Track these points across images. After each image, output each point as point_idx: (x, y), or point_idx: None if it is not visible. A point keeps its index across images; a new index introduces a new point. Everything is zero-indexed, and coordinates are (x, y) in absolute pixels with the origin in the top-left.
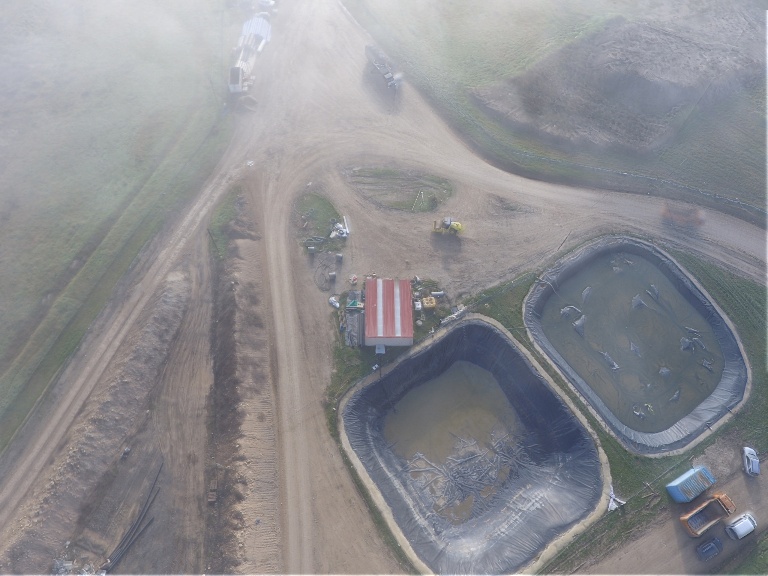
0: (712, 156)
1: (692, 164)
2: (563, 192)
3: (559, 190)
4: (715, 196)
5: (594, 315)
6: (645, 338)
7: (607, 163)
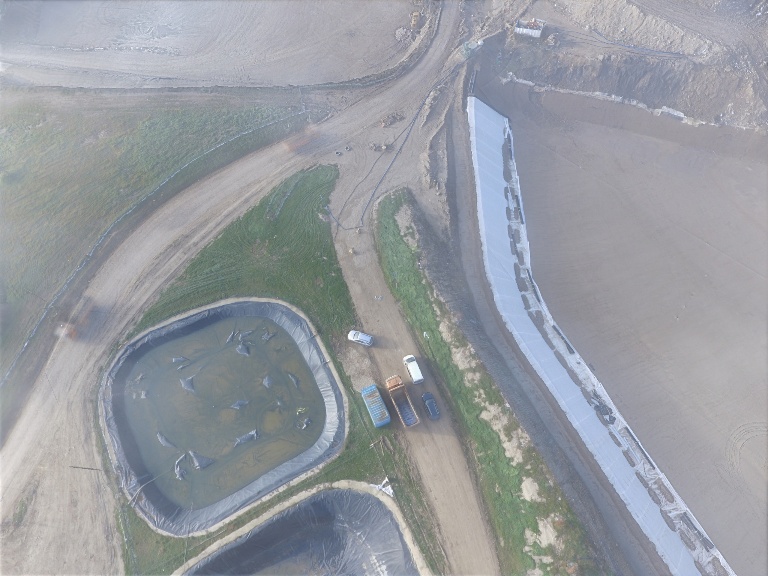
0: (39, 241)
1: (41, 266)
2: (24, 431)
3: (19, 436)
4: (89, 257)
5: (192, 439)
6: (229, 389)
7: (3, 362)
